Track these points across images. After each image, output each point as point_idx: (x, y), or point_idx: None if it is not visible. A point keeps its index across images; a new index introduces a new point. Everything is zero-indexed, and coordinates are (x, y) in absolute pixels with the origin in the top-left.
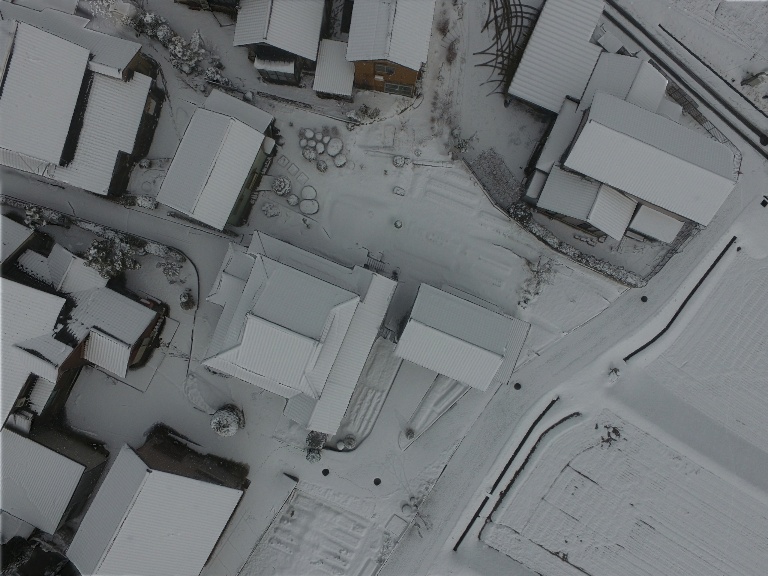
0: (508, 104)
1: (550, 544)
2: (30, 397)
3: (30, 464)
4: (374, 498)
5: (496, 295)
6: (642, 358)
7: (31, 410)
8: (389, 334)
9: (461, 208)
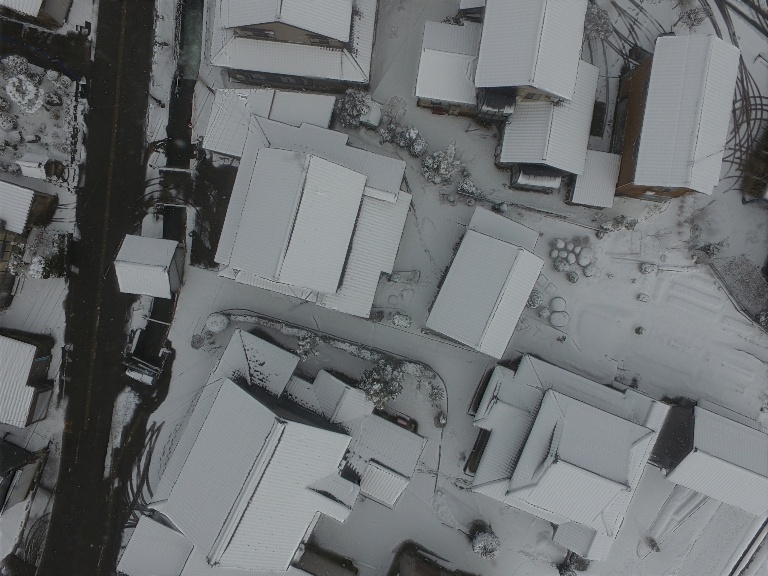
0: (748, 202)
1: None
2: None
3: None
4: None
5: (738, 401)
6: None
7: None
8: None
9: (704, 313)
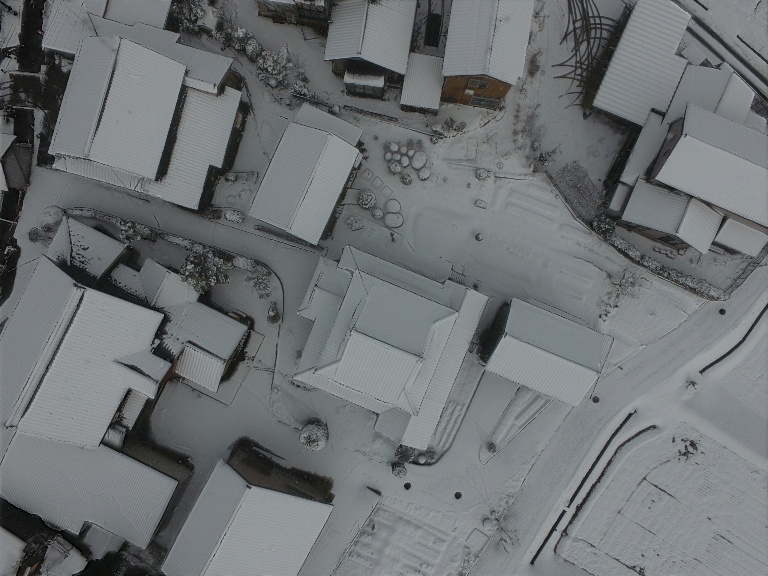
0: (588, 116)
1: (627, 558)
2: (123, 411)
3: (124, 478)
4: (455, 512)
5: (577, 308)
6: (718, 371)
7: (123, 424)
8: (475, 348)
9: (542, 221)
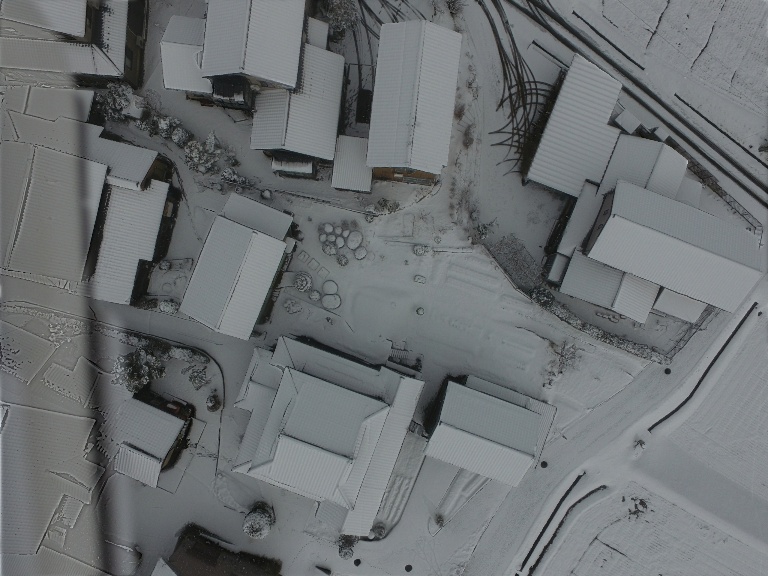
0: (526, 184)
1: None
2: (62, 512)
3: None
4: None
5: (520, 378)
6: (666, 427)
7: (64, 524)
8: (417, 428)
9: (483, 293)
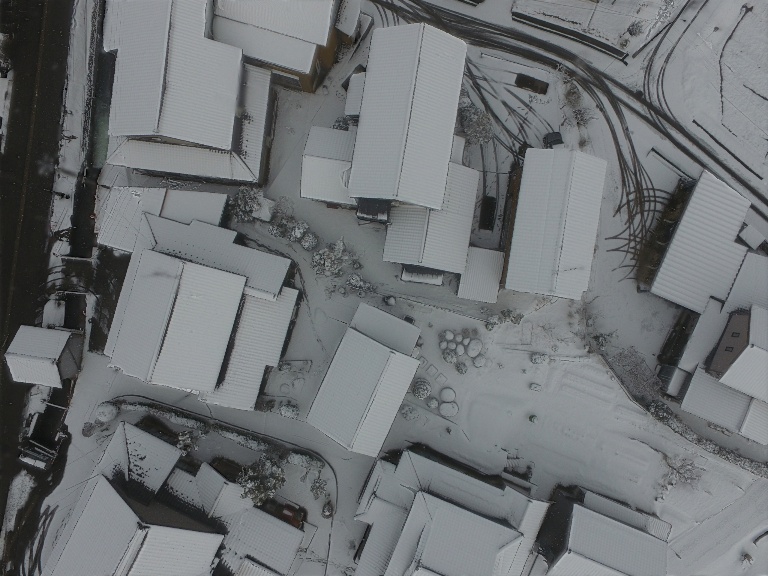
0: (642, 292)
1: None
2: None
3: None
4: None
5: (632, 490)
6: None
7: None
8: None
9: (597, 402)
